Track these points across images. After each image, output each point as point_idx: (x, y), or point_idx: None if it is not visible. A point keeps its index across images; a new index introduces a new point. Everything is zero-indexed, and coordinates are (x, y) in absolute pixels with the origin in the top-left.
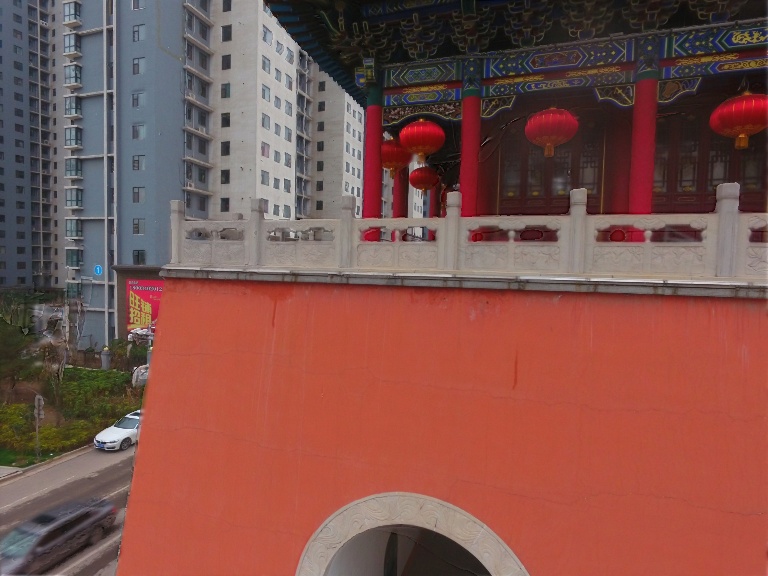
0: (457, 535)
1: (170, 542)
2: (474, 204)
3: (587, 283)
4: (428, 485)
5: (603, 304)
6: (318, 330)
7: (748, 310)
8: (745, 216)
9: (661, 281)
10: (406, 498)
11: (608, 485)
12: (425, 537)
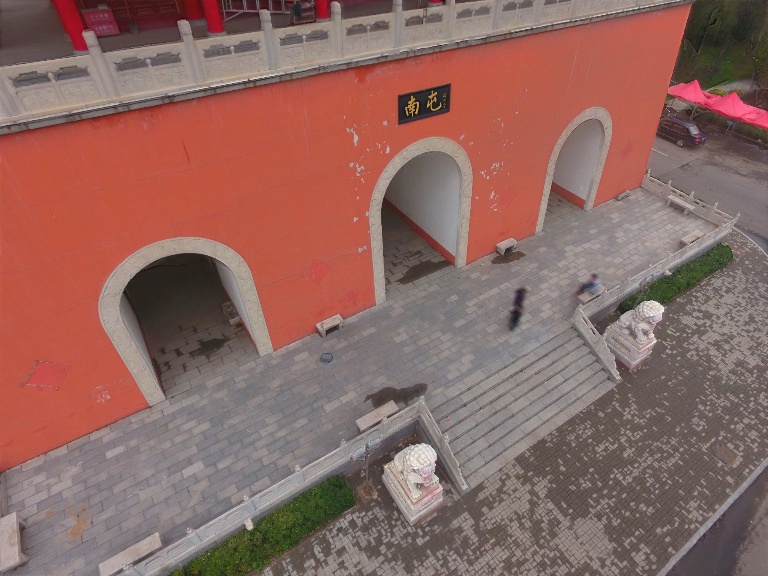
0: (188, 250)
1: None
2: (73, 4)
3: (209, 89)
4: (161, 235)
5: (221, 99)
6: (19, 173)
7: (287, 86)
8: (276, 31)
9: (247, 80)
10: (151, 247)
11: (250, 192)
12: (171, 260)
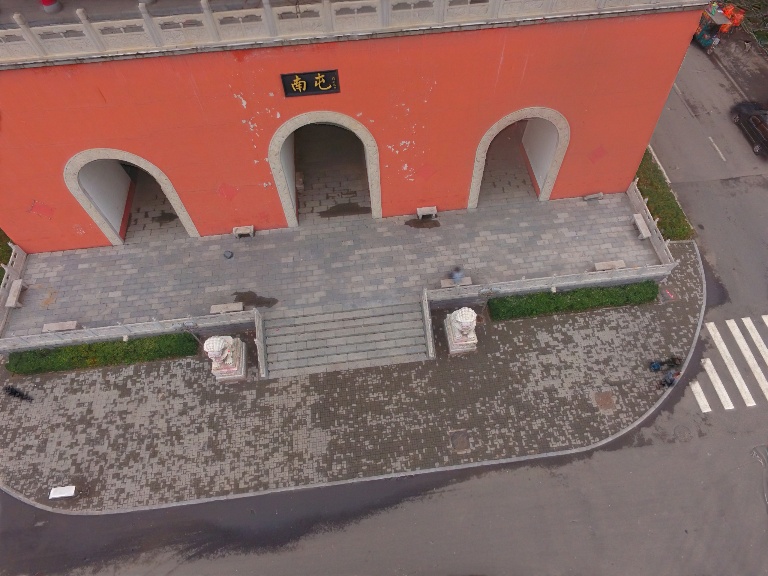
0: (118, 157)
1: (2, 194)
2: None
3: (109, 56)
4: (96, 144)
5: (120, 64)
6: None
7: (173, 59)
8: (154, 19)
9: None
10: (91, 151)
11: (158, 128)
12: (108, 161)
